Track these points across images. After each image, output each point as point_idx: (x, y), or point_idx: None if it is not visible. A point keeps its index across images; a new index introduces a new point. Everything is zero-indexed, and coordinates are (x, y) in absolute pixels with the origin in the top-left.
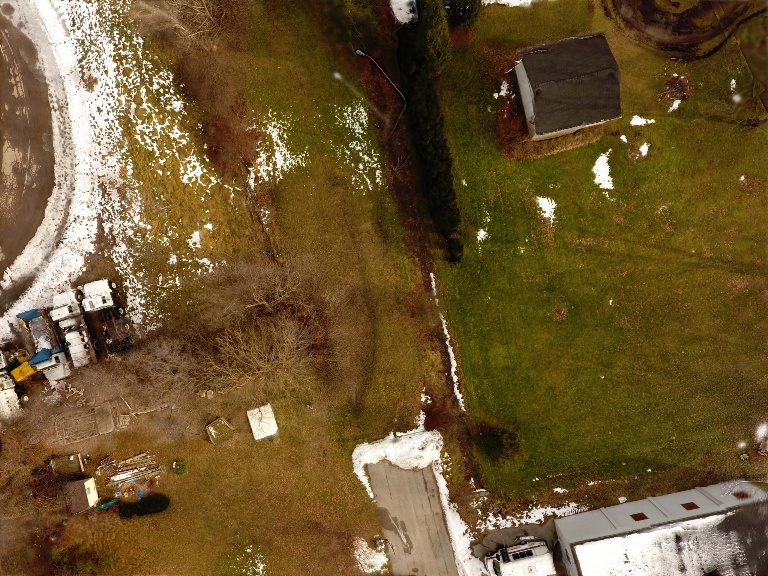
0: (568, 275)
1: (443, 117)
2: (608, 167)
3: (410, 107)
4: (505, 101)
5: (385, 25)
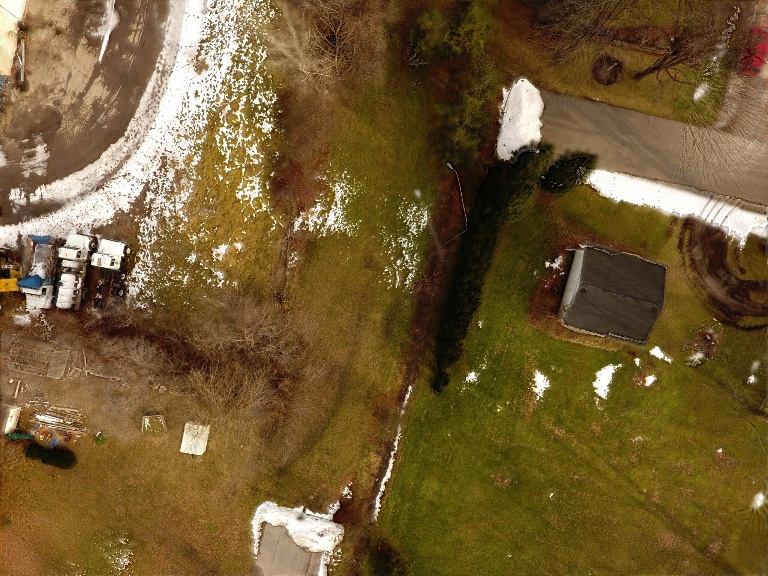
0: (527, 452)
1: (491, 262)
2: (610, 379)
3: (466, 242)
4: (552, 274)
5: (484, 153)
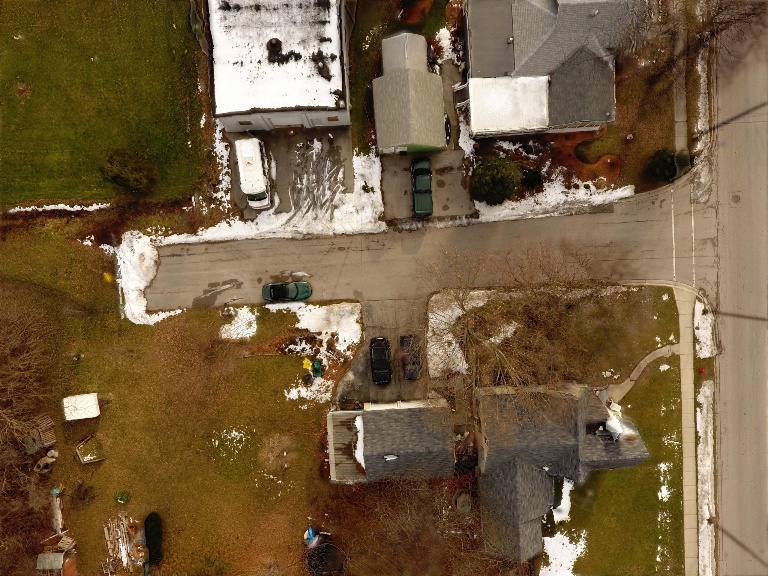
0: None
1: None
2: None
3: None
4: None
5: None
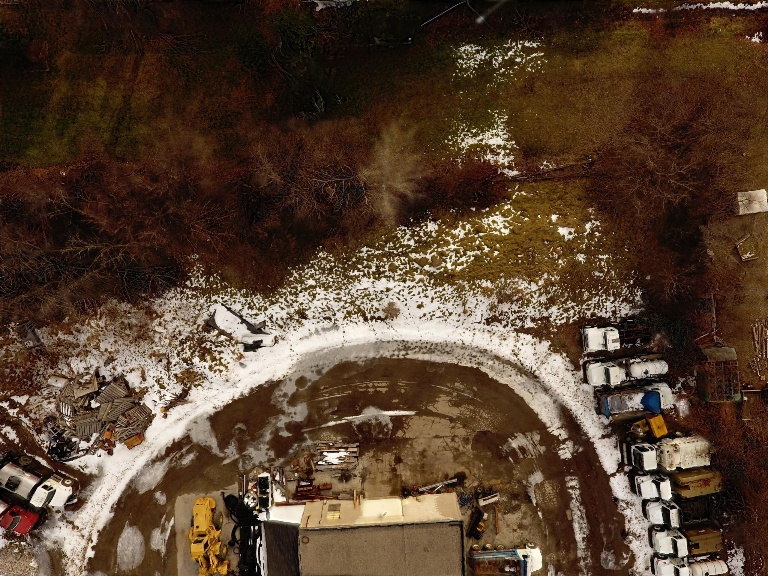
0: None
1: None
2: None
3: None
4: None
5: (386, 8)
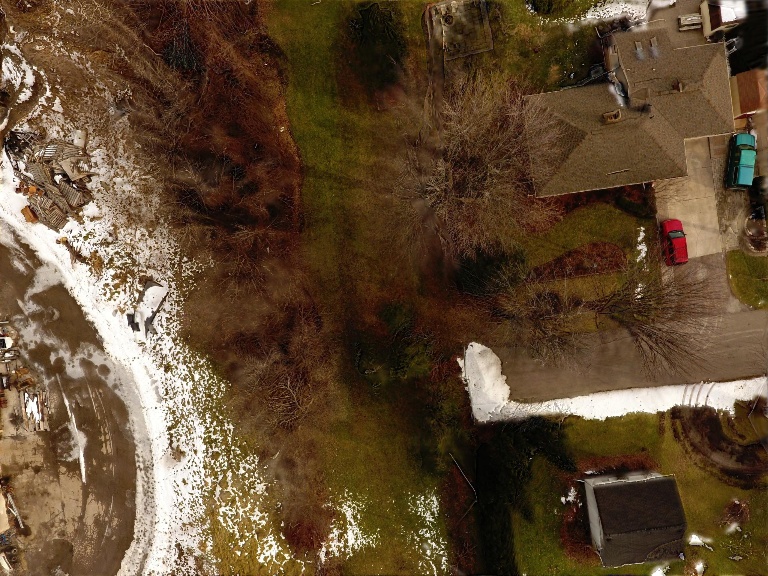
0: None
1: (513, 530)
2: None
3: (485, 534)
4: (572, 509)
5: (464, 425)
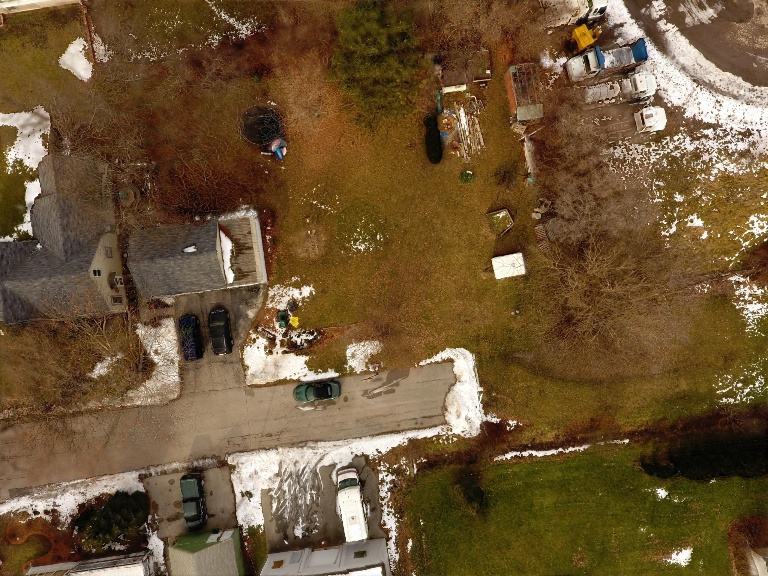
0: (616, 571)
1: None
2: None
3: None
4: None
5: None
